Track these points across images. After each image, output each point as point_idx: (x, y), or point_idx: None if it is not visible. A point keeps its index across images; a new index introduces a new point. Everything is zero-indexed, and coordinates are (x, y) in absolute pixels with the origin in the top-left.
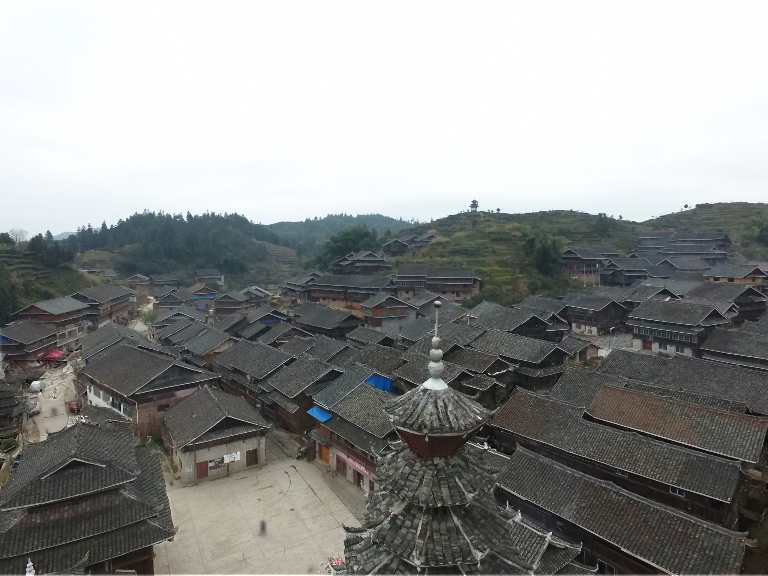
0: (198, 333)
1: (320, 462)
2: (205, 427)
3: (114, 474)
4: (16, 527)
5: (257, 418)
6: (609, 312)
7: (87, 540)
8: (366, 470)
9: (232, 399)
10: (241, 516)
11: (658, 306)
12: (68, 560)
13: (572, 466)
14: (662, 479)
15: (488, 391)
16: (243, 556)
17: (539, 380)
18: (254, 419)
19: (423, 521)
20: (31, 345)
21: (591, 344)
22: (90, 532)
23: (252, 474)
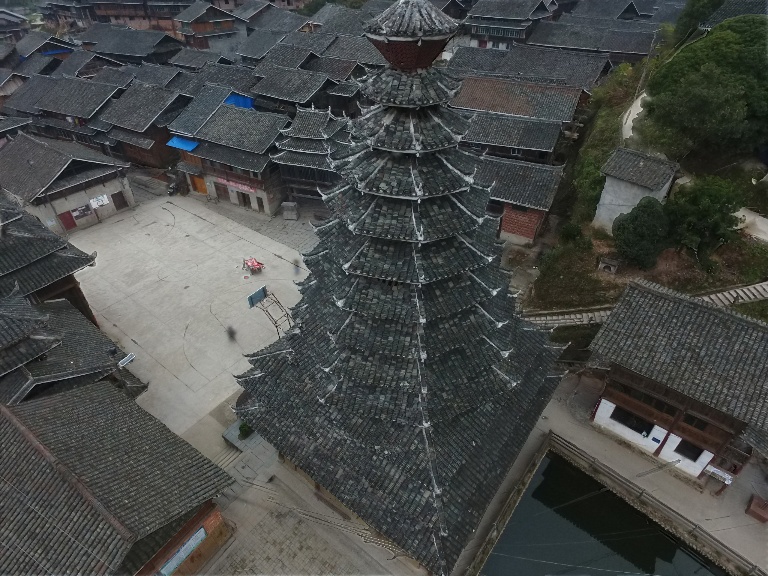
0: None
1: (196, 194)
2: (51, 175)
3: None
4: None
5: (108, 159)
6: (449, 13)
7: None
8: (251, 188)
9: (64, 144)
10: (137, 250)
11: (495, 1)
12: None
13: None
14: (507, 144)
15: (354, 98)
16: (158, 277)
17: None
18: (106, 160)
19: (413, 123)
20: None
21: None
22: None
23: (127, 216)
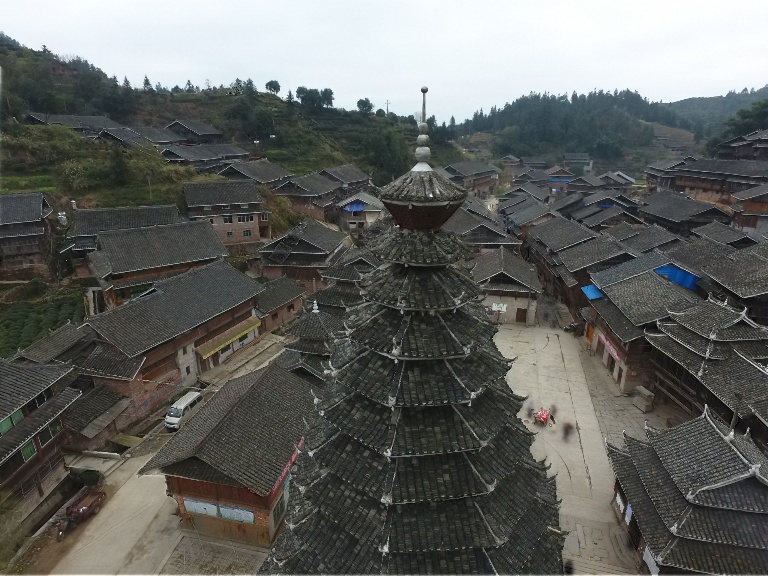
0: None
1: (585, 340)
2: (483, 277)
3: None
4: (329, 289)
5: (534, 283)
6: None
7: None
8: (618, 356)
9: (521, 263)
10: None
11: None
12: None
13: None
14: None
15: None
16: None
17: None
18: (529, 282)
19: (385, 274)
20: None
21: None
22: None
23: (517, 329)
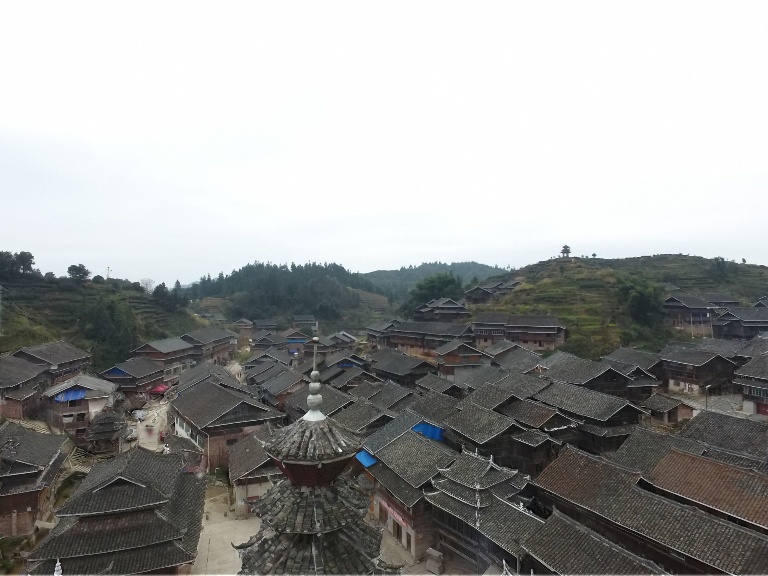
0: (278, 374)
1: None
2: (257, 462)
3: (151, 494)
4: (67, 533)
5: None
6: (714, 368)
7: (121, 553)
8: (403, 521)
9: None
10: None
11: None
12: (102, 569)
13: (621, 540)
14: (722, 566)
15: (541, 448)
16: None
17: (607, 440)
18: None
19: (282, 547)
20: (142, 379)
21: (682, 404)
22: (123, 546)
23: None
